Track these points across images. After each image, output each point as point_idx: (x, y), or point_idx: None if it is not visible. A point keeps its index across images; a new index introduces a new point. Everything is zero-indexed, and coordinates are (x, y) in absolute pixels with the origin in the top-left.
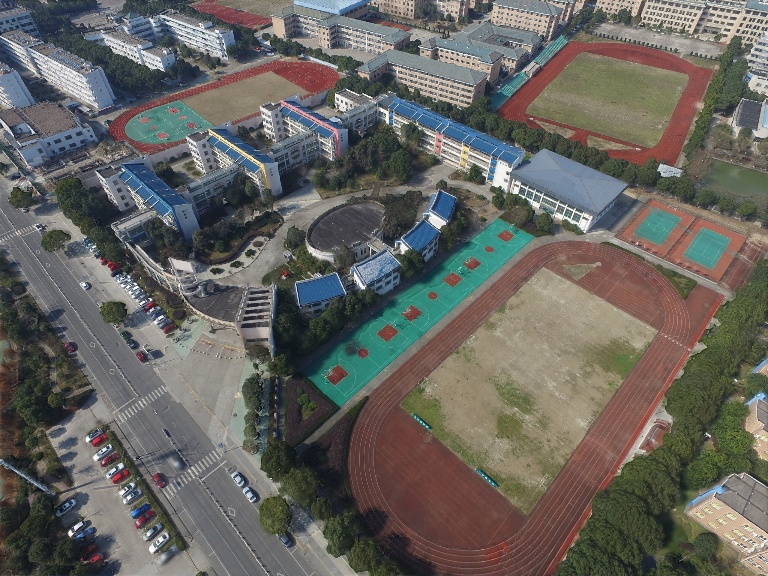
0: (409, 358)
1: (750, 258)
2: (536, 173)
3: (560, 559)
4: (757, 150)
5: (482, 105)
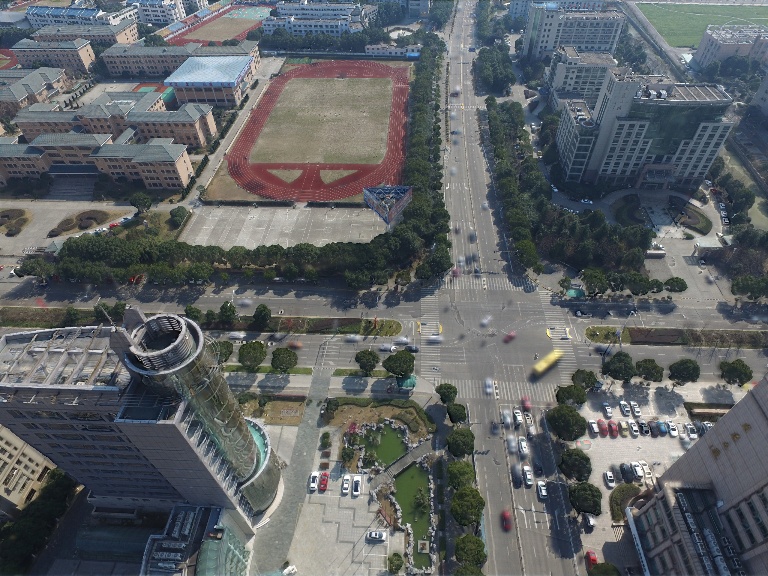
0: None
1: None
2: (24, 13)
3: None
4: None
5: None
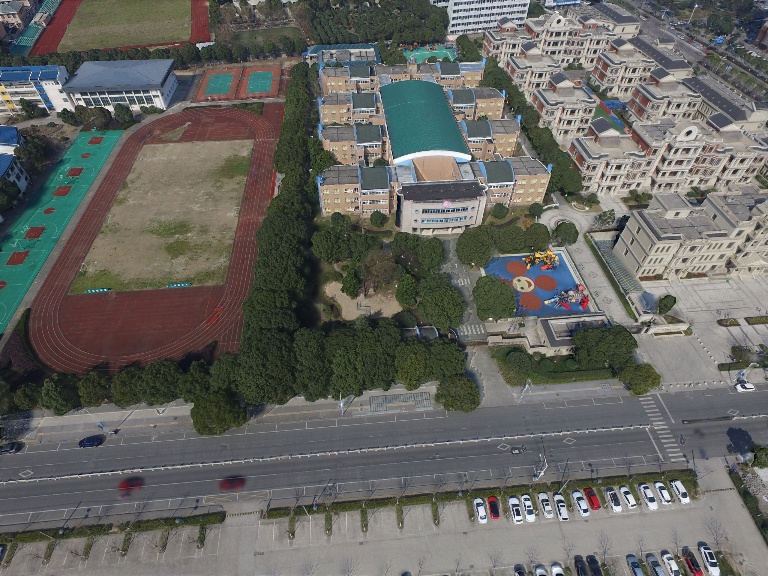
0: (55, 261)
1: (289, 76)
2: (87, 79)
3: None
4: (260, 15)
5: None
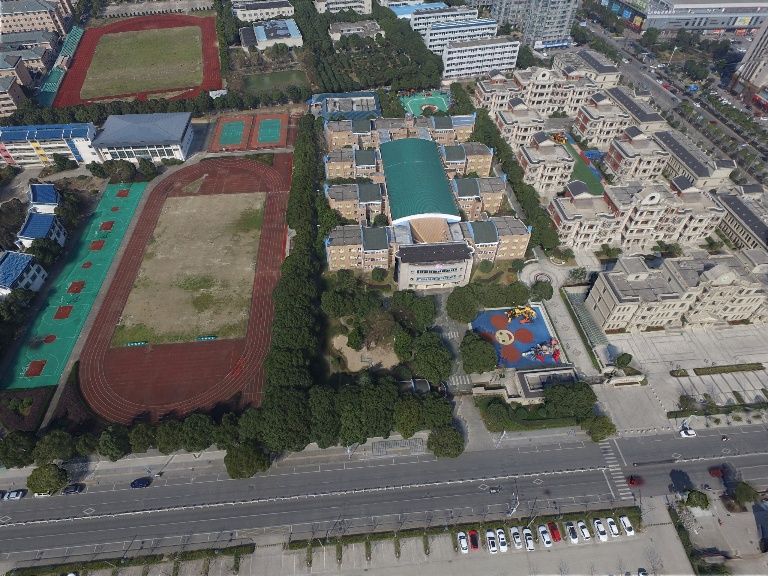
0: (96, 315)
1: (296, 124)
2: (113, 135)
3: None
4: (267, 59)
5: (29, 106)
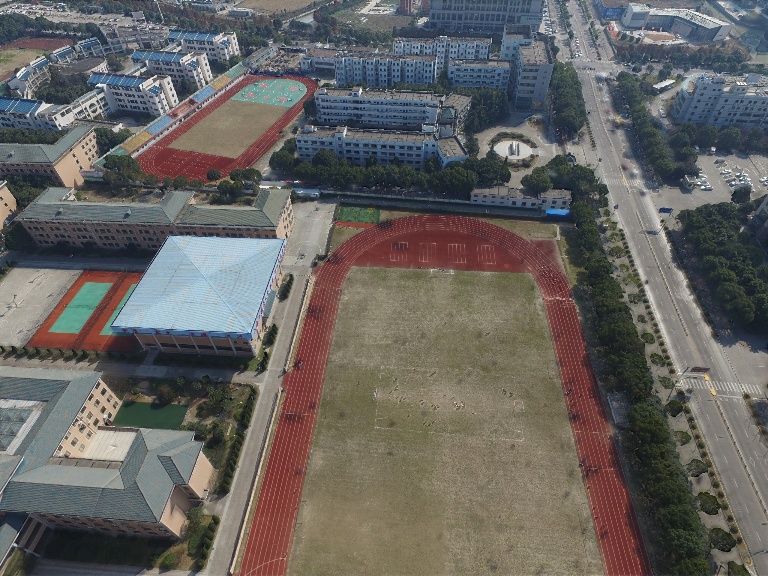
0: None
1: None
2: None
3: (3, 45)
4: None
5: None
